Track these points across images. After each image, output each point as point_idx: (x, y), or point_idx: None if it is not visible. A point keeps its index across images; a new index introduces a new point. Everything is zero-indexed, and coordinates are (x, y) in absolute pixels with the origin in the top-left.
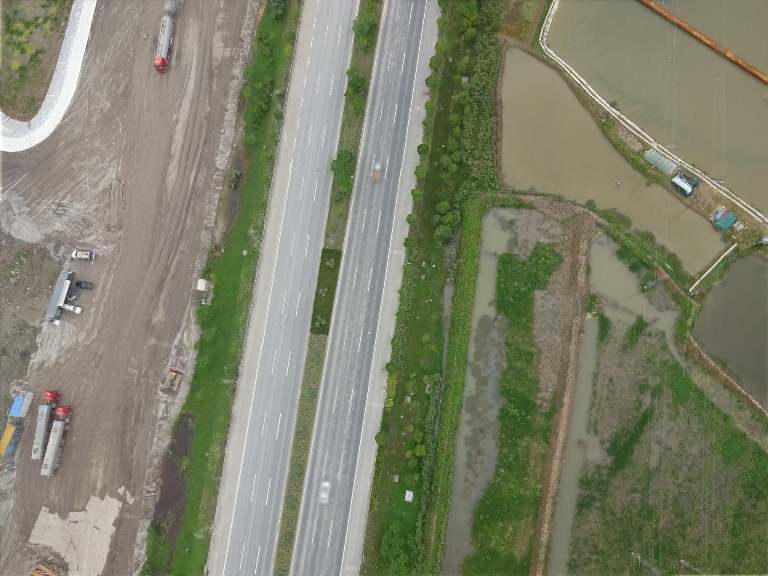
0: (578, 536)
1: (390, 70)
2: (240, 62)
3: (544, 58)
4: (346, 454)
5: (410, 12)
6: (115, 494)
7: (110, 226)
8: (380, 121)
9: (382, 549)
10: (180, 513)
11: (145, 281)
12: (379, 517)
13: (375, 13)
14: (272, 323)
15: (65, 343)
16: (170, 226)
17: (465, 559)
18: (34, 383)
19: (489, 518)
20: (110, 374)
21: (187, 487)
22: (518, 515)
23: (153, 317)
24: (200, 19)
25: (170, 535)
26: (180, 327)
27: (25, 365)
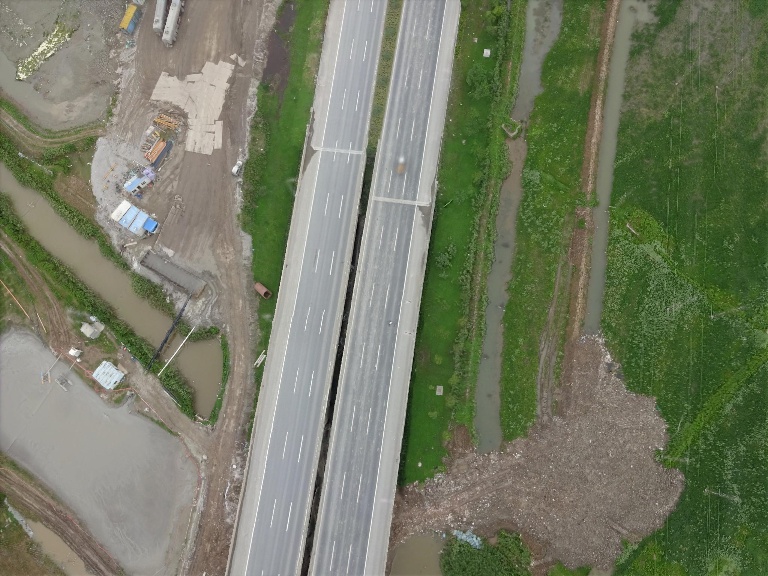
0: (631, 74)
1: None
2: None
3: None
4: (432, 20)
5: None
6: (228, 59)
7: None
8: None
9: (468, 78)
10: (286, 75)
11: None
12: (462, 66)
13: None
14: None
15: None
16: None
17: (536, 95)
18: None
19: (556, 64)
20: None
21: (291, 55)
22: (580, 61)
23: None
24: None
25: (278, 92)
26: None
27: None
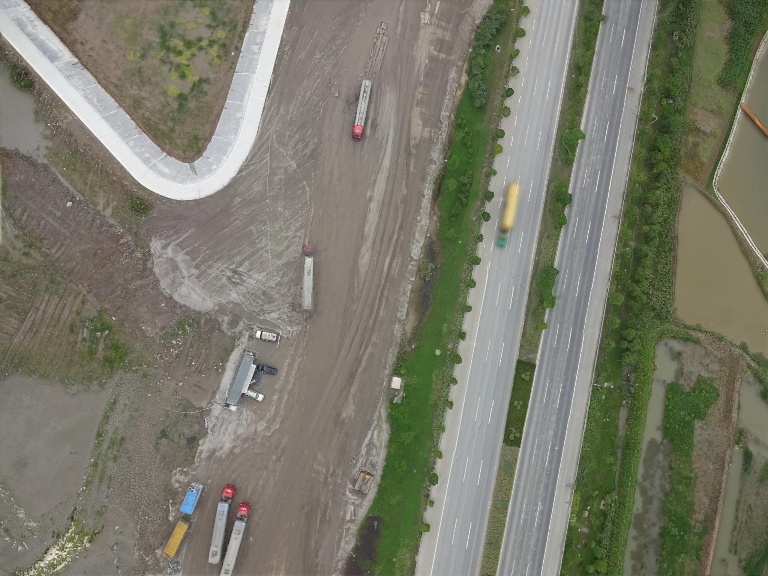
0: None
1: (585, 186)
2: (439, 146)
3: (716, 202)
4: (532, 565)
5: (606, 131)
6: None
7: (295, 305)
8: (574, 237)
9: None
10: None
11: (334, 372)
12: None
13: (576, 125)
14: (465, 430)
15: (242, 432)
16: (362, 314)
17: None
18: (203, 474)
19: None
20: (293, 470)
21: None
22: None
23: (342, 412)
24: (398, 88)
25: None
26: (371, 425)
27: (192, 452)
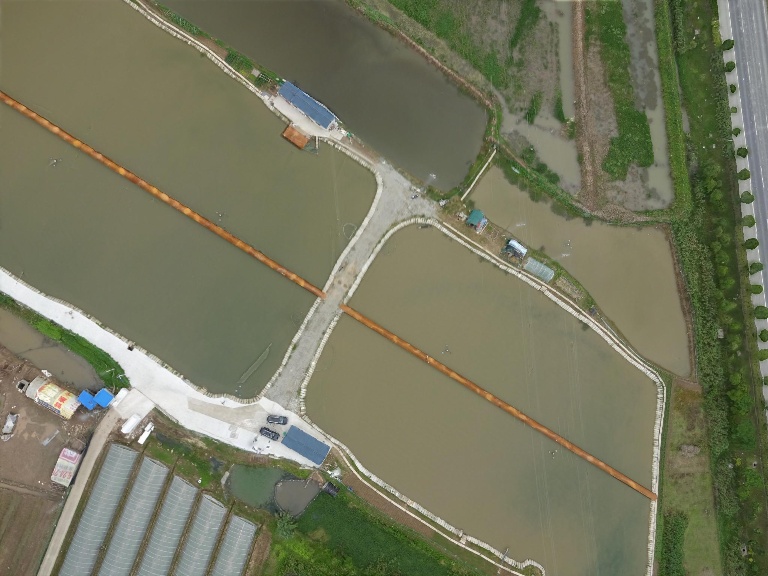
0: None
1: None
2: None
3: (657, 367)
4: None
5: None
6: None
7: None
8: None
9: None
10: None
11: None
12: None
13: None
14: None
15: None
16: None
17: None
18: None
19: None
20: None
21: None
22: None
23: None
24: None
25: None
26: None
27: None
